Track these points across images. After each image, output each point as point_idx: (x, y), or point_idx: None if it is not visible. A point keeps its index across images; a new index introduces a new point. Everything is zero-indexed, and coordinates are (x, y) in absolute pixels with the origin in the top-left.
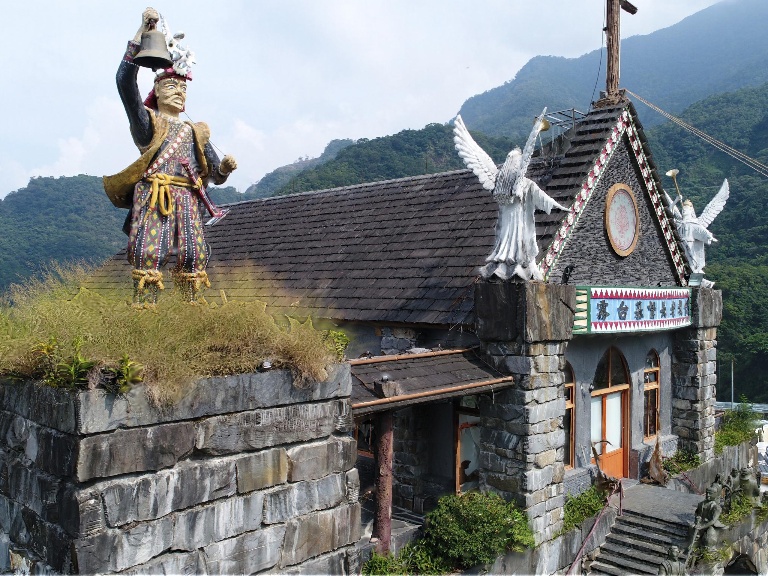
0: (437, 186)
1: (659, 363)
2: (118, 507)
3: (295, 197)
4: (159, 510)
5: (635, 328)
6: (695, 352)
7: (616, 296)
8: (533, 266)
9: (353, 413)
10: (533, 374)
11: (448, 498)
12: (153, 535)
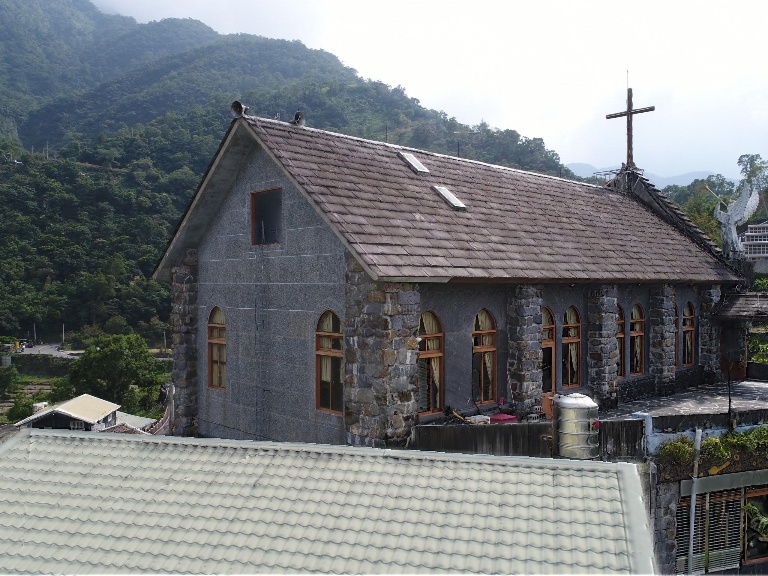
0: None
1: None
2: None
3: None
4: None
5: None
6: None
7: None
8: None
9: None
10: None
11: None
12: None
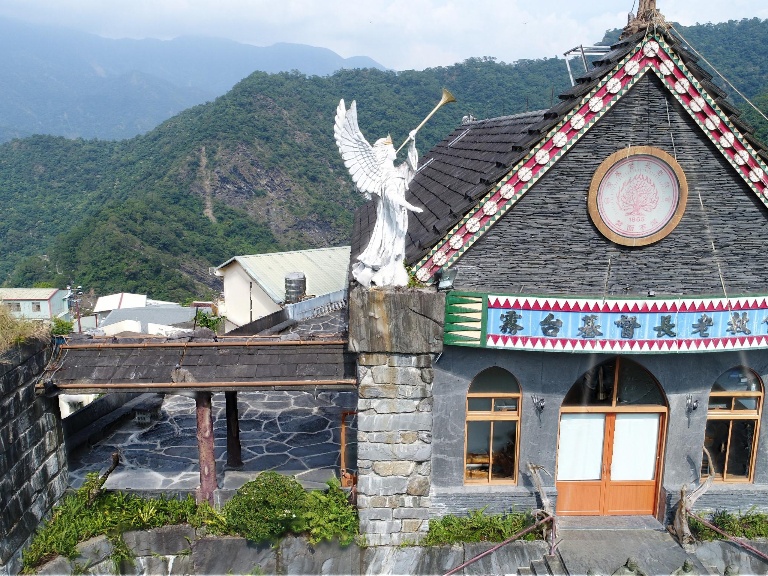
0: None
1: (763, 387)
2: None
3: (495, 122)
4: None
5: (575, 348)
6: None
7: (537, 307)
8: (395, 268)
9: (127, 391)
10: (365, 383)
11: (268, 474)
12: None
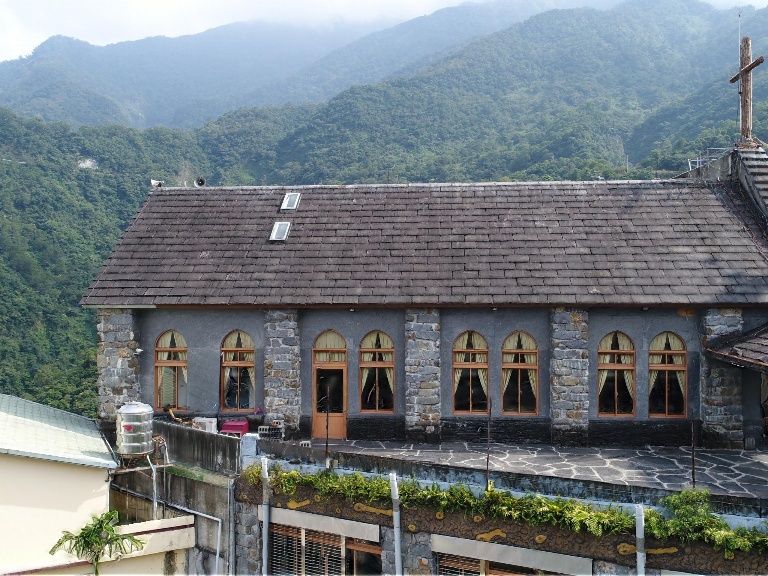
0: (608, 193)
1: None
2: None
3: (404, 188)
4: None
5: None
6: None
7: None
8: None
9: None
10: None
11: None
12: None
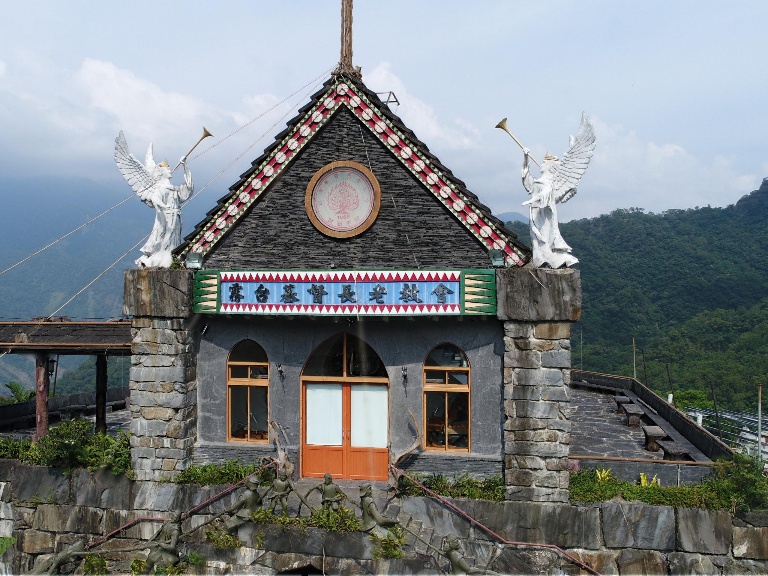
0: None
1: (469, 362)
2: None
3: None
4: None
5: (279, 311)
6: None
7: (252, 279)
8: None
9: None
10: (136, 342)
11: None
12: None
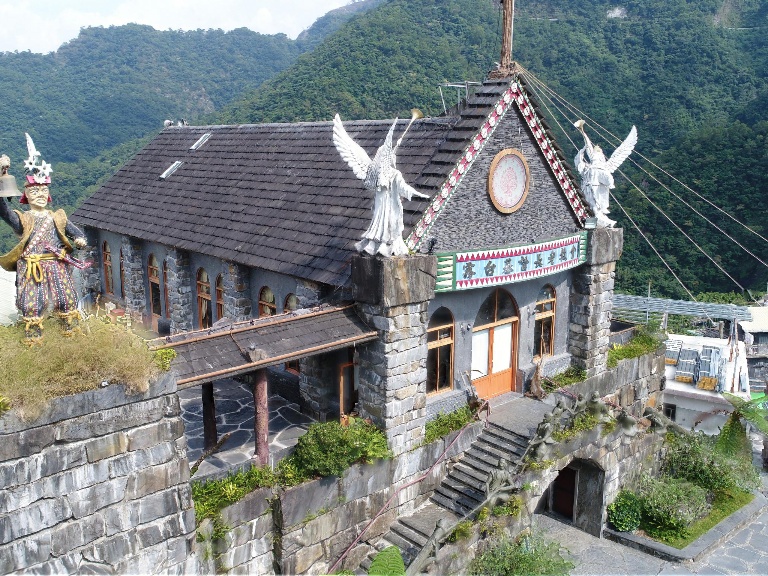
0: (367, 136)
1: (555, 295)
2: (4, 479)
3: (263, 128)
4: (32, 478)
5: (503, 282)
6: (588, 285)
7: (483, 257)
8: (399, 242)
9: None
10: (392, 331)
11: (317, 425)
12: (30, 491)
